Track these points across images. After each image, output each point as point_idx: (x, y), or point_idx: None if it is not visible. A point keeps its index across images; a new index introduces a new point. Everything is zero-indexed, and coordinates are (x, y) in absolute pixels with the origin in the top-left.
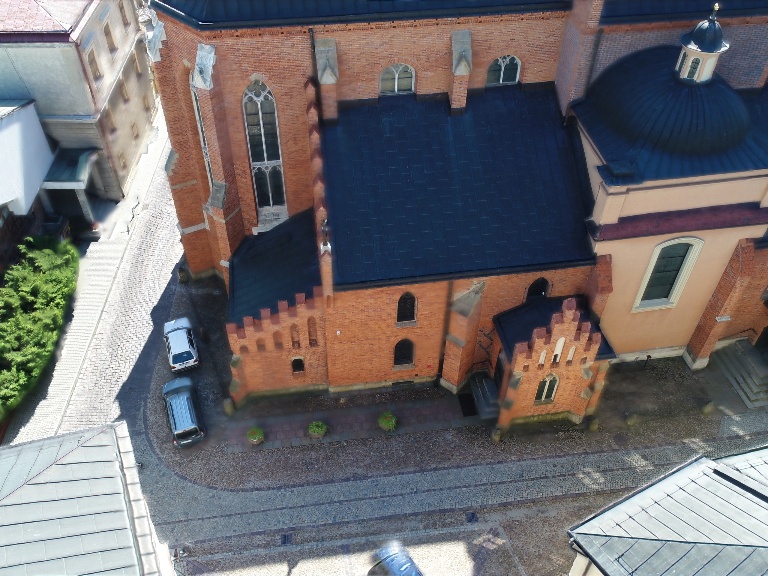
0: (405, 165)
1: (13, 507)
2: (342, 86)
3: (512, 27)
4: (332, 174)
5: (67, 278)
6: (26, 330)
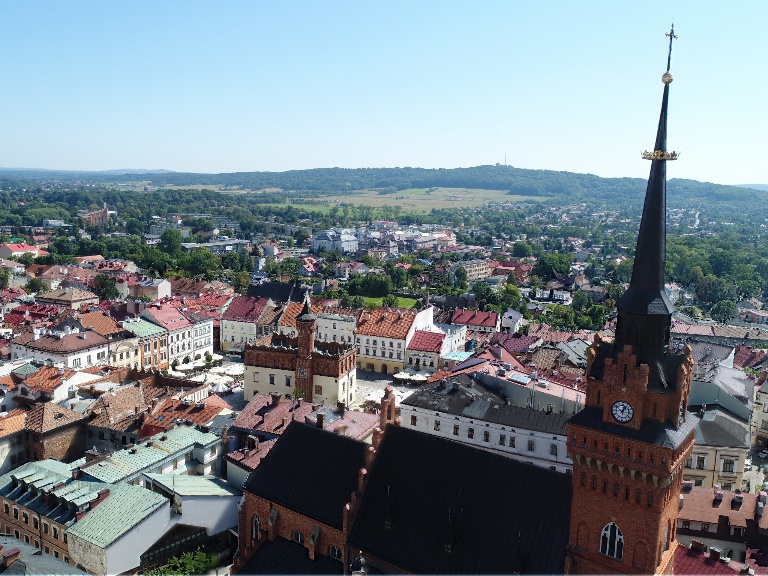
0: (278, 571)
1: (61, 574)
2: (280, 529)
3: (335, 533)
4: (255, 561)
5: (198, 567)
6: (166, 575)
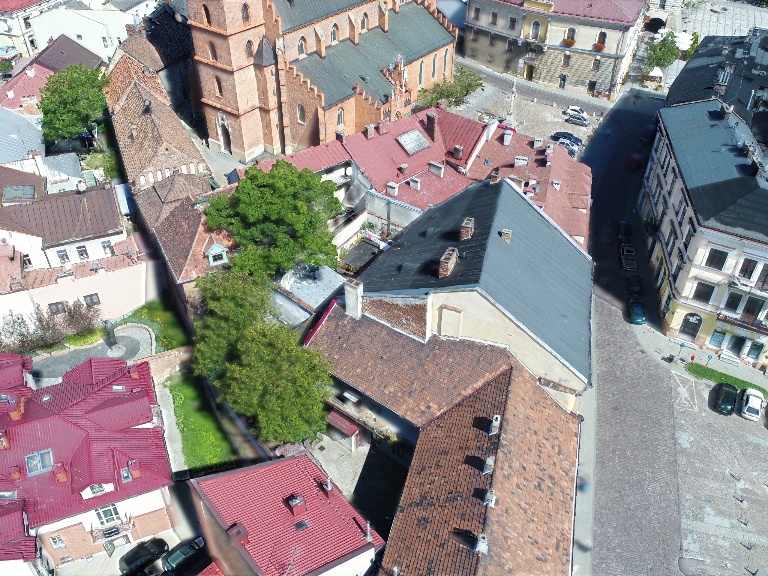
0: None
1: None
2: None
3: None
4: None
5: None
6: None
